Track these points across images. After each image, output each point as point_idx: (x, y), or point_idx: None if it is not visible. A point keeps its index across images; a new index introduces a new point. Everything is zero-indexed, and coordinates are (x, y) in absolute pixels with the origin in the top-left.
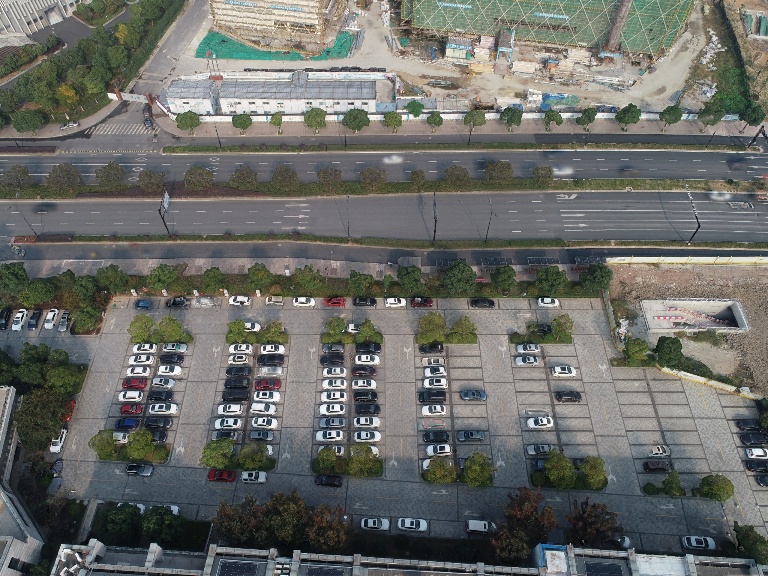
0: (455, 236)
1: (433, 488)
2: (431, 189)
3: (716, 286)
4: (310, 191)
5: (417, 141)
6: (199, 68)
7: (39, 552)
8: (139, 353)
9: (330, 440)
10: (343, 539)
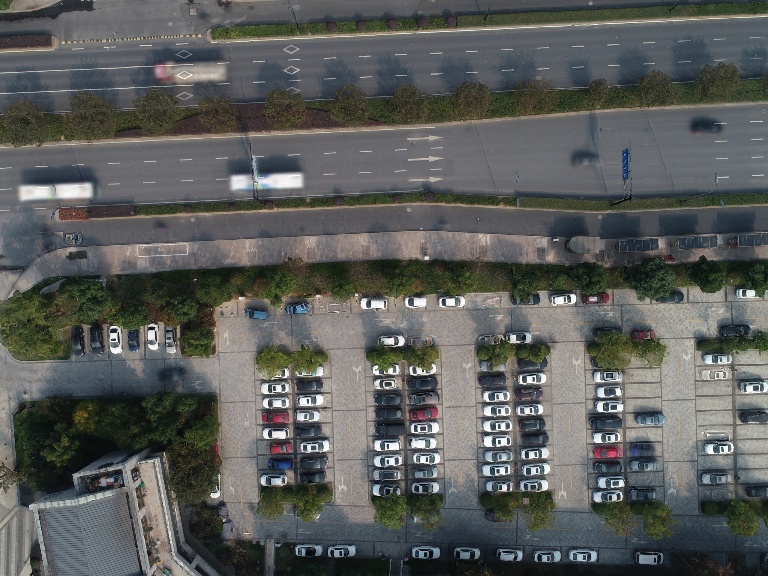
0: (640, 188)
1: (603, 518)
2: (611, 105)
3: None
4: (441, 114)
5: (591, 0)
6: None
7: None
8: (270, 379)
9: None
10: None
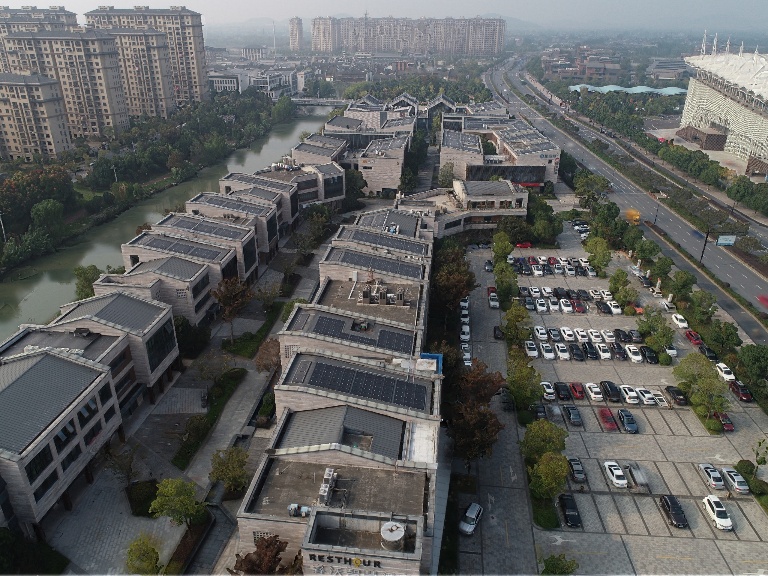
0: None
1: None
2: None
3: None
4: None
5: None
6: None
7: None
8: None
9: (536, 333)
10: (441, 283)
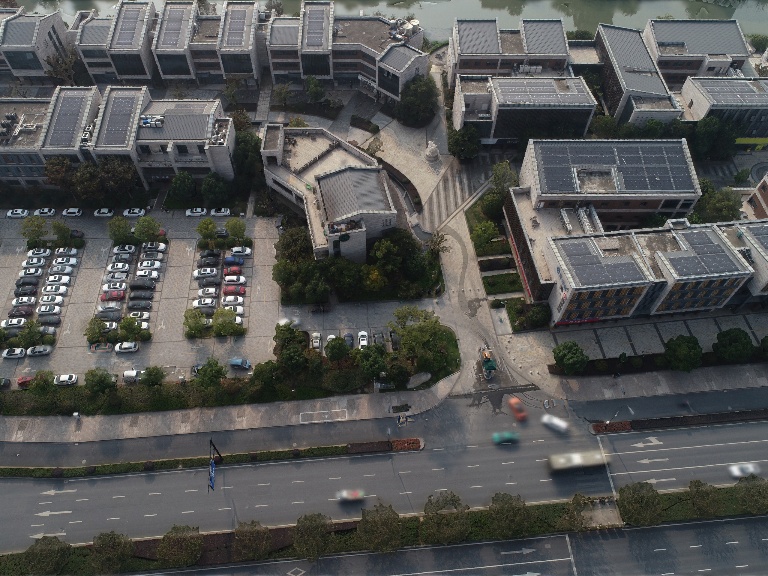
0: None
1: None
2: None
3: None
4: None
5: None
6: None
7: None
8: None
9: None
10: None
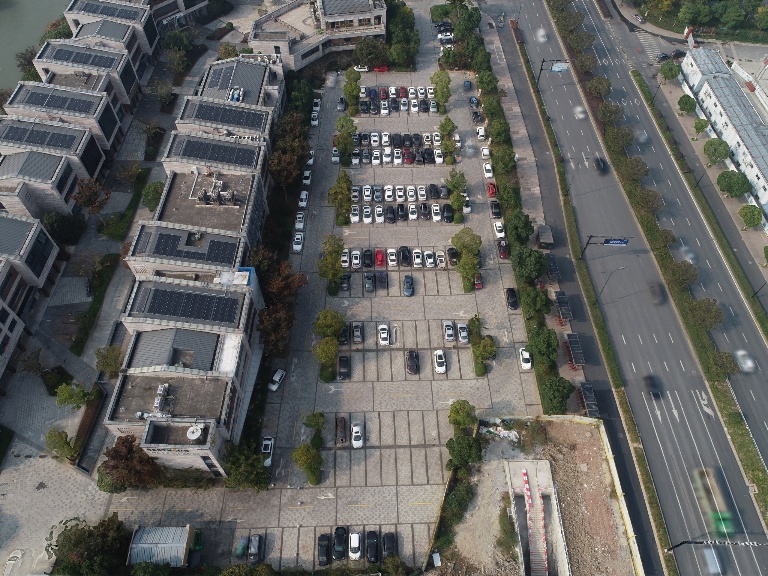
0: (598, 281)
1: None
2: (660, 259)
3: (598, 573)
4: (619, 165)
5: (738, 250)
6: (760, 74)
7: (290, 69)
8: None
9: None
10: (273, 169)
